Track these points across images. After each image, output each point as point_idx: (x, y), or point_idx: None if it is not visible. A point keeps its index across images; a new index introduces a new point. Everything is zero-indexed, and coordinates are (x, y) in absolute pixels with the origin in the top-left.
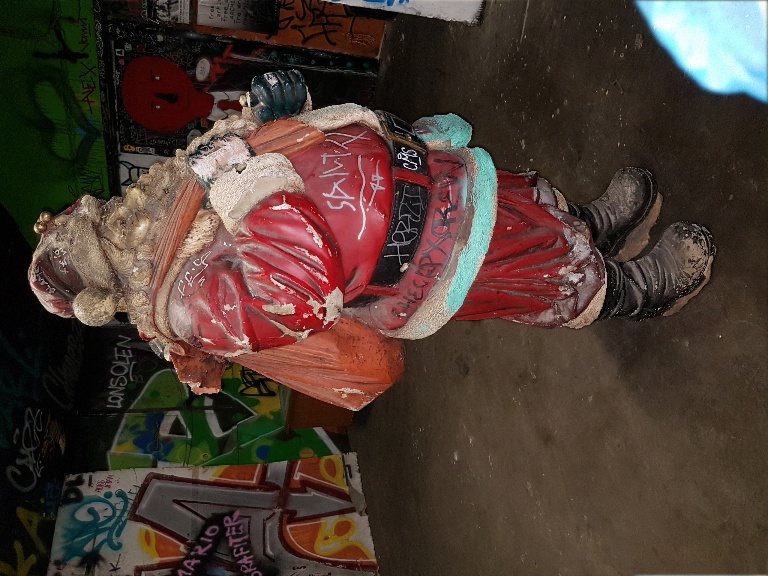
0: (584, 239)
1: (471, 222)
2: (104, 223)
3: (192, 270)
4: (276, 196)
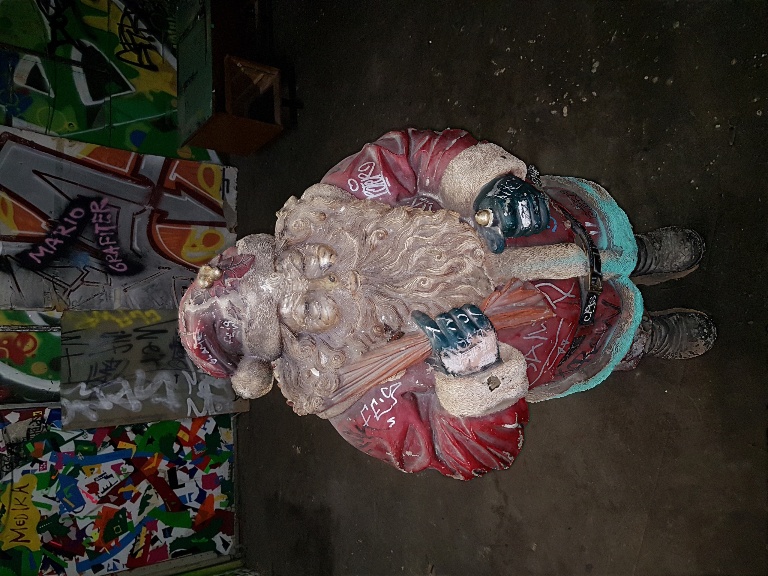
0: (645, 340)
1: (601, 368)
2: (287, 306)
3: (380, 401)
4: (509, 411)
